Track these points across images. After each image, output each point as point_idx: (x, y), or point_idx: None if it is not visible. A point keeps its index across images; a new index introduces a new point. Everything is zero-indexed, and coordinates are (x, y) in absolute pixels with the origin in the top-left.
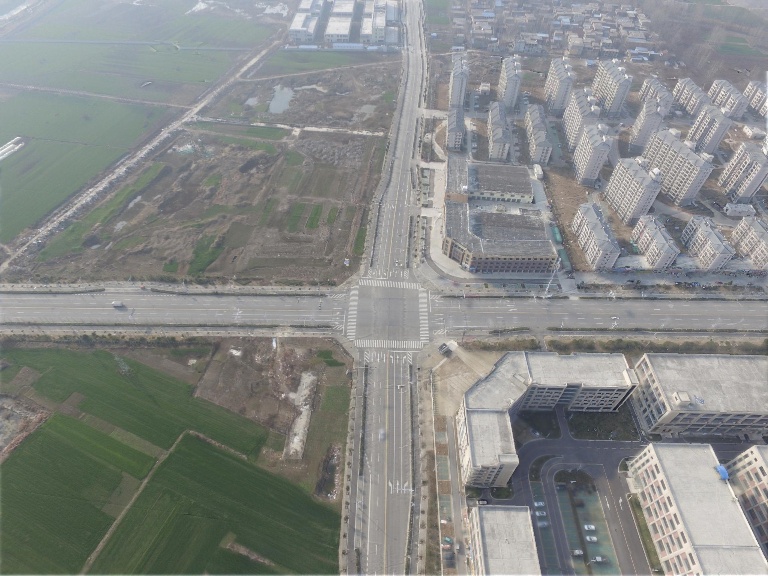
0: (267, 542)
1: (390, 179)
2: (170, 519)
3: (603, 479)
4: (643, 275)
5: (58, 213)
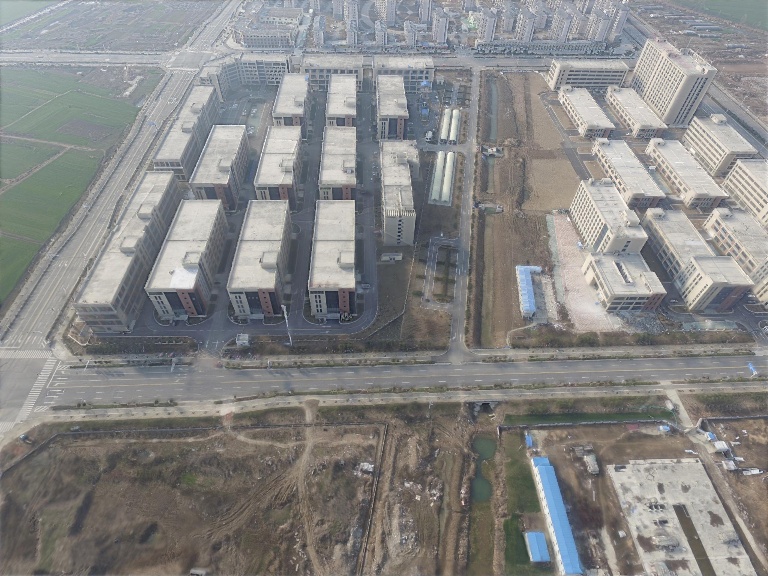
0: (105, 114)
1: (218, 16)
2: (60, 108)
3: (271, 100)
4: (343, 49)
5: (6, 26)
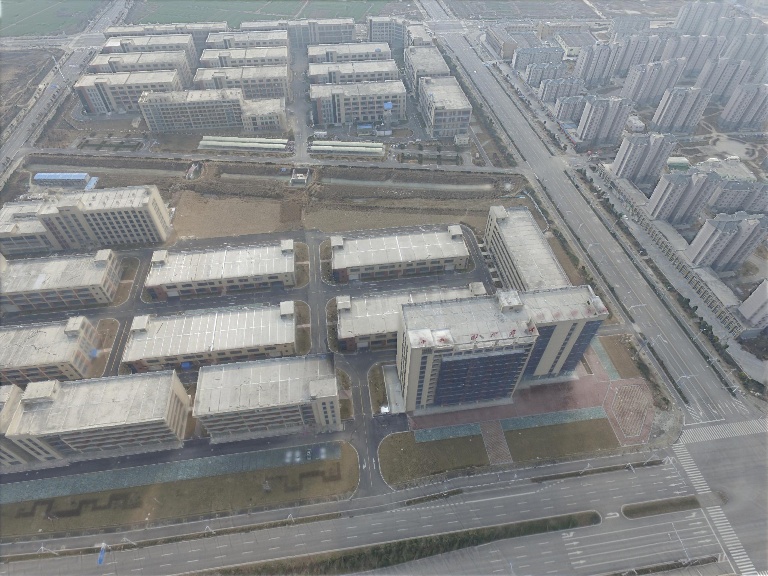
0: None
1: None
2: None
3: None
4: (519, 82)
5: None
